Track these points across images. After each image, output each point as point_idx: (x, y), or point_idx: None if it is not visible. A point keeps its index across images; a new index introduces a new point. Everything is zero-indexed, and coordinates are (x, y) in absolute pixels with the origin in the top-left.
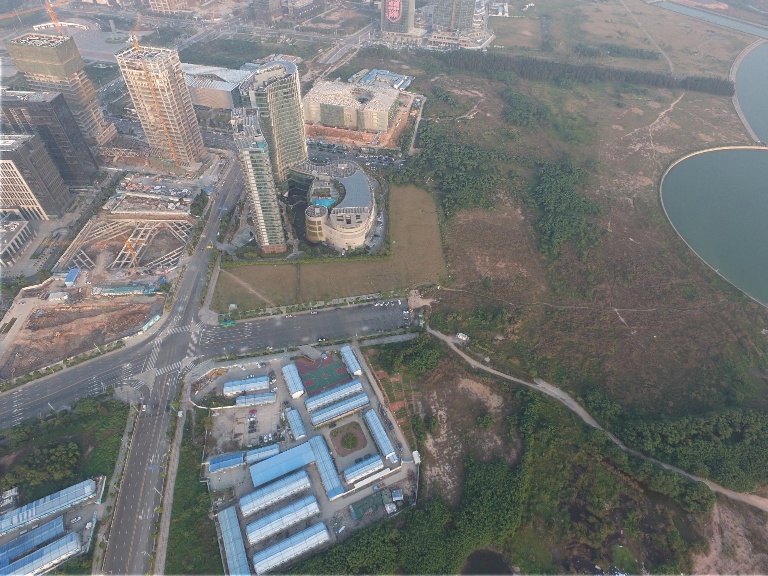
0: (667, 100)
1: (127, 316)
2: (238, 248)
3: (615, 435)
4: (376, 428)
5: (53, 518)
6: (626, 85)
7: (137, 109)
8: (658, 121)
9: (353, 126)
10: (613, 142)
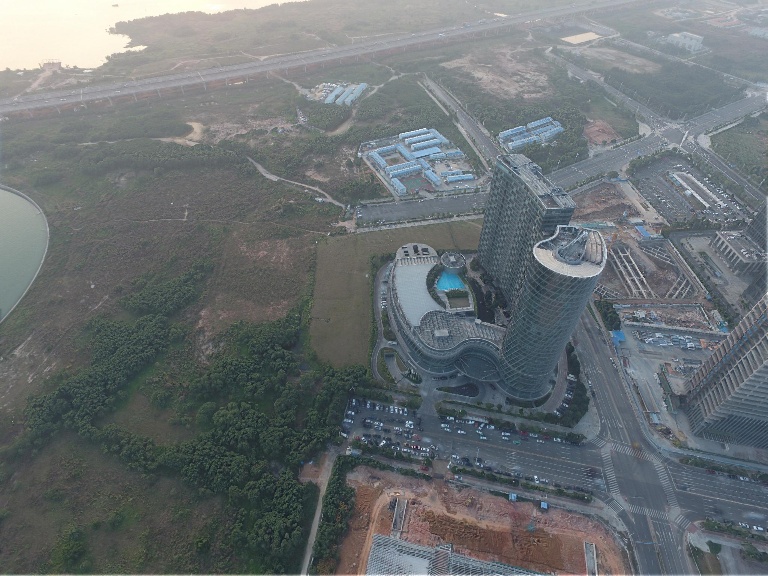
0: None
1: None
2: None
3: None
4: (381, 158)
5: None
6: None
7: None
8: None
9: None
10: None
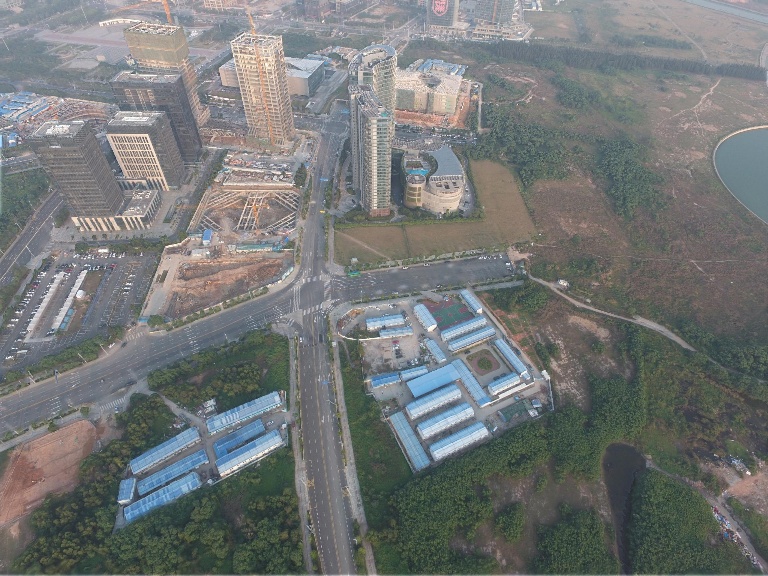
0: (706, 85)
1: (264, 268)
2: (348, 212)
3: (712, 358)
4: (508, 352)
5: (252, 421)
6: (666, 72)
7: (242, 91)
8: (701, 103)
9: (422, 109)
10: (663, 122)
